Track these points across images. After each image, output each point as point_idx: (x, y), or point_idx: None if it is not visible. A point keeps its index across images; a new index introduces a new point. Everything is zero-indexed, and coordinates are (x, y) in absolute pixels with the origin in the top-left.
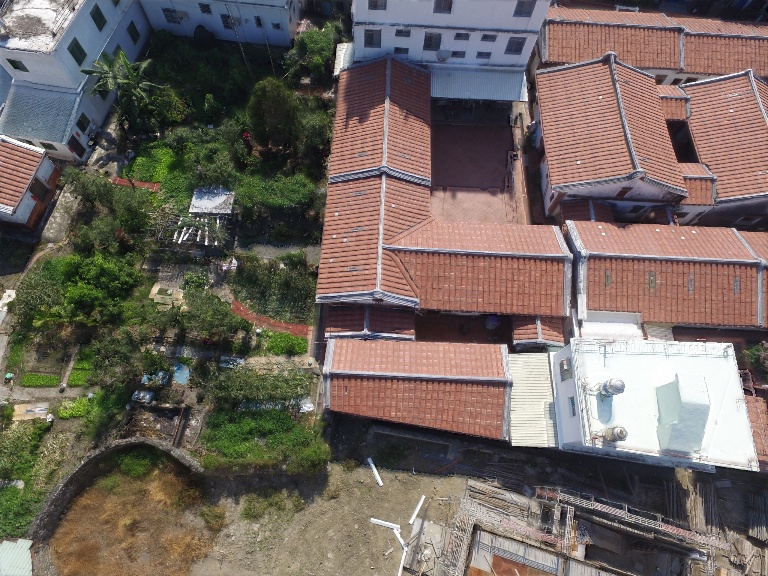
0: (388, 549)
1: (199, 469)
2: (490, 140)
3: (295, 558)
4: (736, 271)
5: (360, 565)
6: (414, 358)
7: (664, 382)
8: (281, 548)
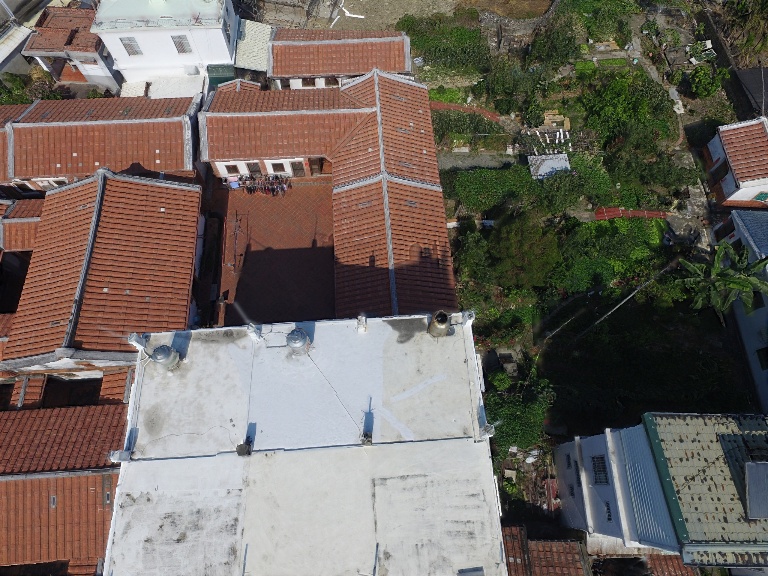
0: (352, 7)
1: (478, 10)
2: (255, 317)
3: (408, 2)
4: (40, 121)
5: (368, 2)
6: (342, 58)
7: (158, 6)
8: (417, 5)
